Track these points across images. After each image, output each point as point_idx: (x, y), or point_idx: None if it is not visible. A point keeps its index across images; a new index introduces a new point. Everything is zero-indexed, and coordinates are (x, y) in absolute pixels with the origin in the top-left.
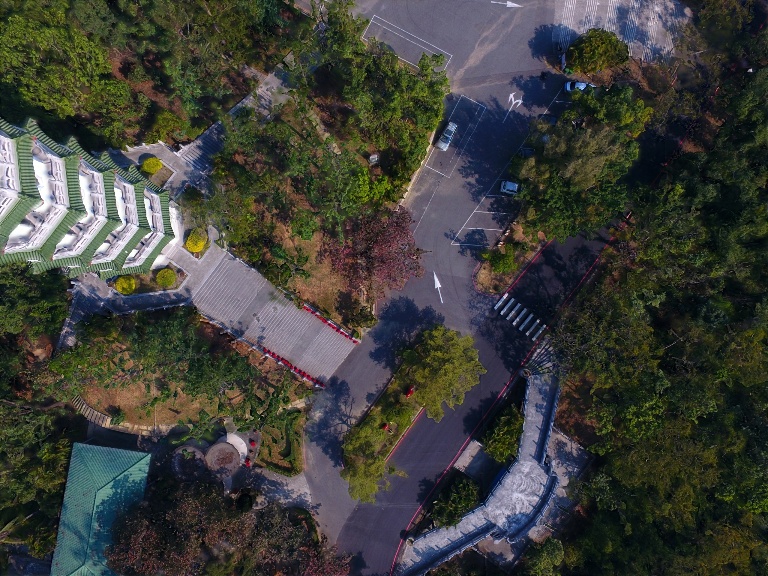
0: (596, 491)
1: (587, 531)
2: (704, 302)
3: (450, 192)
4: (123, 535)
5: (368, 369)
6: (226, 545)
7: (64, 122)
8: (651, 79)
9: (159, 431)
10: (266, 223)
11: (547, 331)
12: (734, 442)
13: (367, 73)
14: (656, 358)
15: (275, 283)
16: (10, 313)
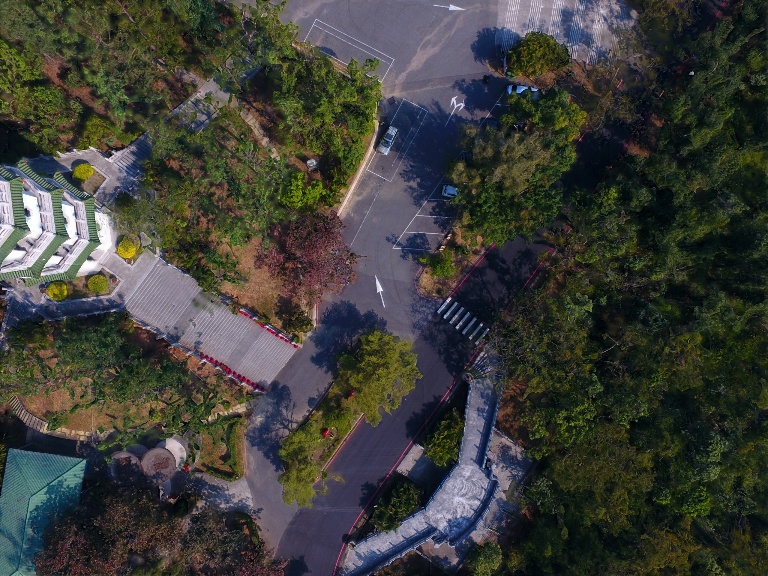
0: (537, 495)
1: (532, 534)
2: (644, 306)
3: (392, 196)
4: (52, 541)
5: (309, 373)
6: (154, 551)
7: None
8: (596, 82)
9: (96, 436)
10: (201, 228)
11: None
12: (669, 446)
13: (299, 78)
14: (597, 362)
15: None
16: None
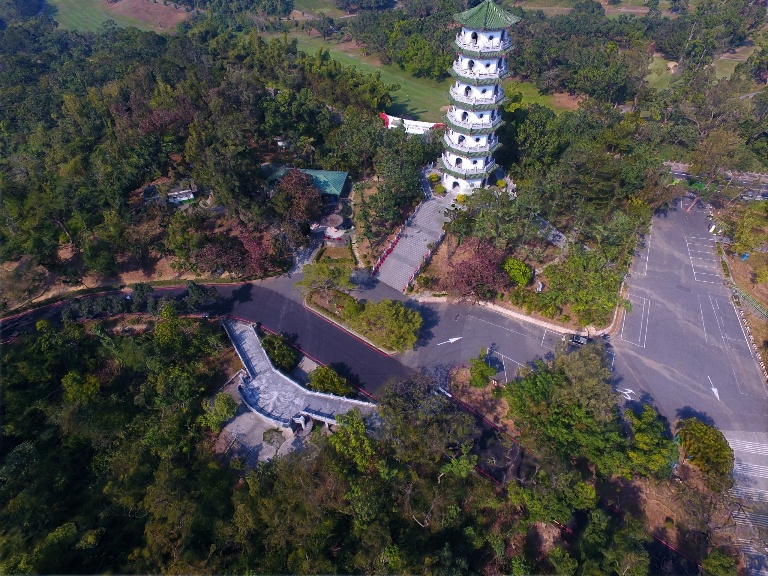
0: (268, 462)
1: None
2: None
3: (530, 346)
4: None
5: None
6: None
7: None
8: None
9: (350, 202)
10: None
11: None
12: (314, 568)
13: None
14: None
15: None
16: None
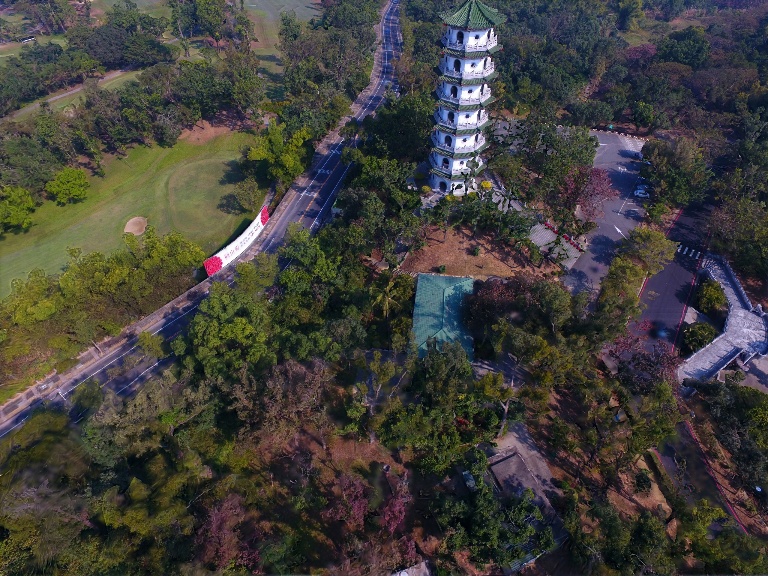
0: None
1: None
2: None
3: None
4: None
5: (594, 266)
6: None
7: None
8: None
9: None
10: None
11: (703, 255)
12: None
13: None
14: None
15: (536, 197)
16: None
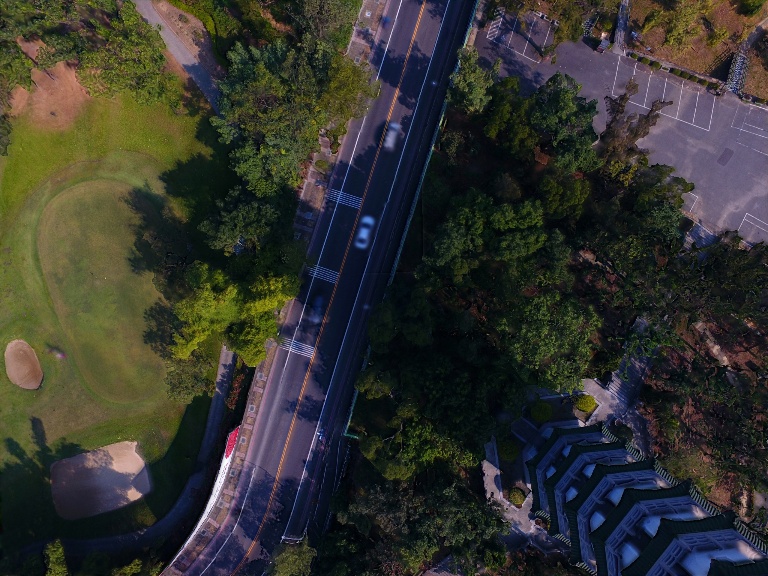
0: None
1: None
2: None
3: None
4: None
5: None
6: None
7: (483, 348)
8: None
9: None
10: (676, 450)
11: None
12: None
13: None
14: None
15: None
16: (472, 570)
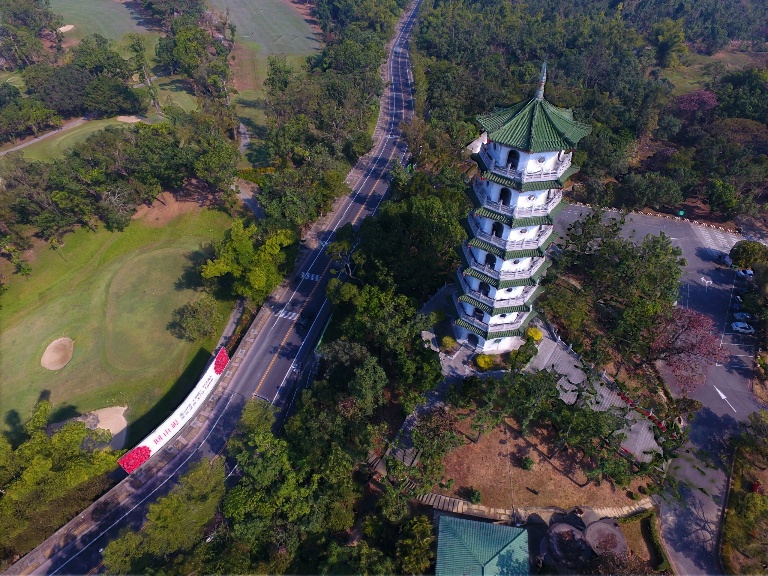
0: None
1: None
2: None
3: None
4: None
5: None
6: None
7: None
8: None
9: (519, 515)
10: None
11: None
12: None
13: None
14: None
15: (610, 361)
16: None
